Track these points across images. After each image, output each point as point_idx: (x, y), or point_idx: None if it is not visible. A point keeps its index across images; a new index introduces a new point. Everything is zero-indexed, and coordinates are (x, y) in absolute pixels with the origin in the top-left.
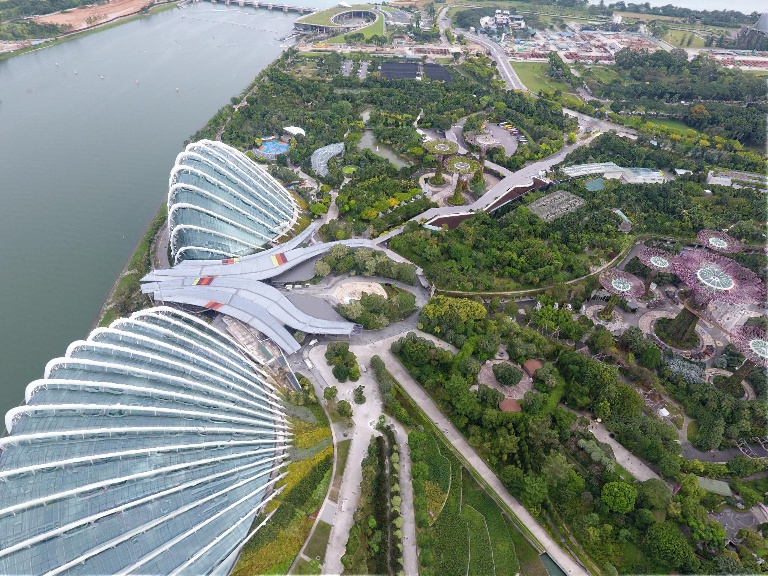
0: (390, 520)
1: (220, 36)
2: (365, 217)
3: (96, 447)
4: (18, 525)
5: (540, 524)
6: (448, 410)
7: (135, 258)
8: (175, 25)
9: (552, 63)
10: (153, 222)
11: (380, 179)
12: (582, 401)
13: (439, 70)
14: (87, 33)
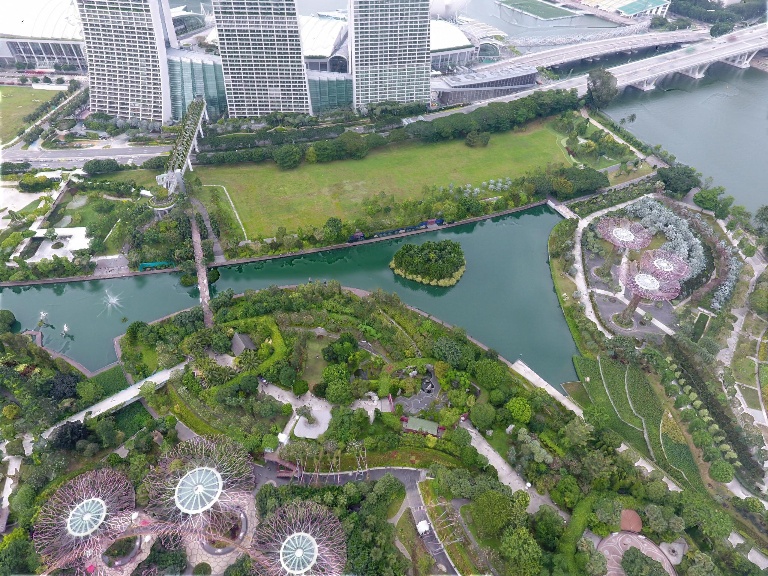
0: None
1: None
2: None
3: None
4: None
5: None
6: None
7: None
8: None
9: None
10: None
11: None
12: (550, 507)
13: None
14: None
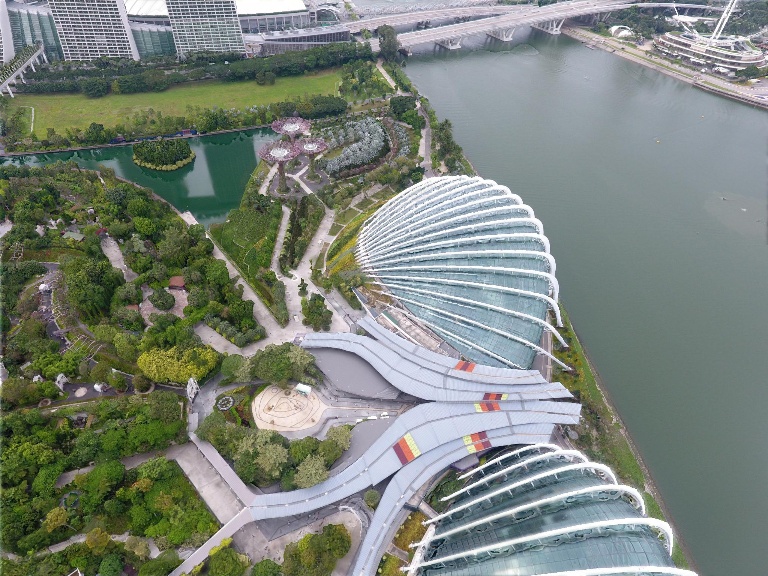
0: None
1: None
2: None
3: None
4: None
5: None
6: None
7: None
8: None
9: None
10: None
11: None
12: (118, 268)
13: None
14: None
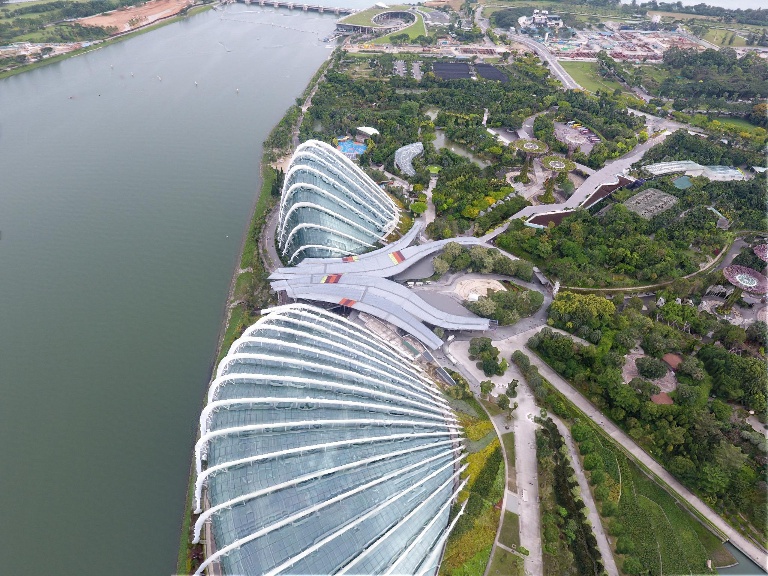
0: (577, 509)
1: (264, 37)
2: (468, 215)
3: (299, 439)
4: (250, 514)
5: (717, 513)
6: (602, 403)
7: (245, 257)
8: (216, 27)
9: (602, 62)
10: (252, 221)
11: (466, 178)
12: (736, 394)
13: (491, 70)
14: (132, 35)
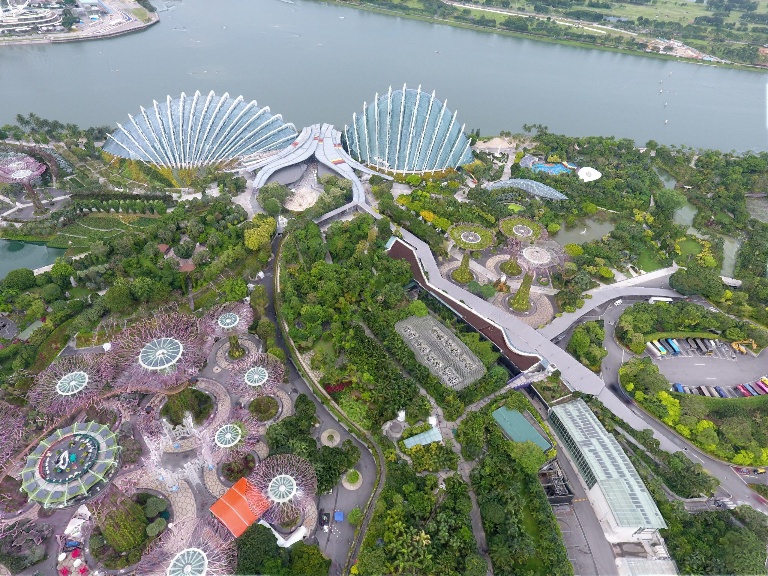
0: None
1: None
2: None
3: None
4: None
5: None
6: None
7: None
8: None
9: None
10: None
11: None
12: None
13: None
14: None
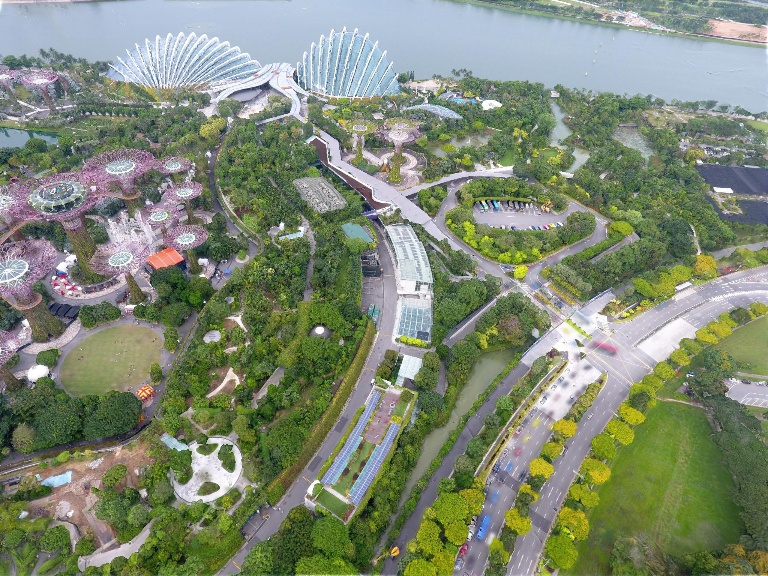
0: None
1: None
2: None
3: None
4: None
5: None
6: None
7: None
8: None
9: None
10: None
11: None
12: None
13: None
14: (711, 40)
